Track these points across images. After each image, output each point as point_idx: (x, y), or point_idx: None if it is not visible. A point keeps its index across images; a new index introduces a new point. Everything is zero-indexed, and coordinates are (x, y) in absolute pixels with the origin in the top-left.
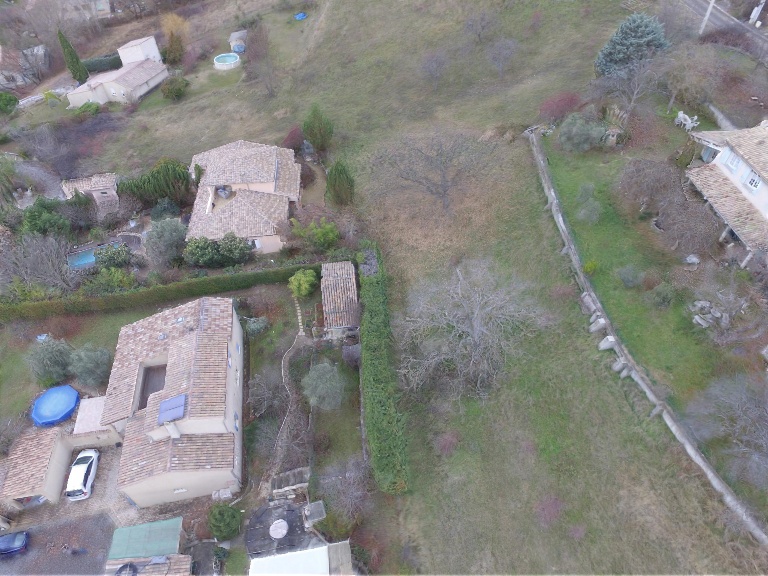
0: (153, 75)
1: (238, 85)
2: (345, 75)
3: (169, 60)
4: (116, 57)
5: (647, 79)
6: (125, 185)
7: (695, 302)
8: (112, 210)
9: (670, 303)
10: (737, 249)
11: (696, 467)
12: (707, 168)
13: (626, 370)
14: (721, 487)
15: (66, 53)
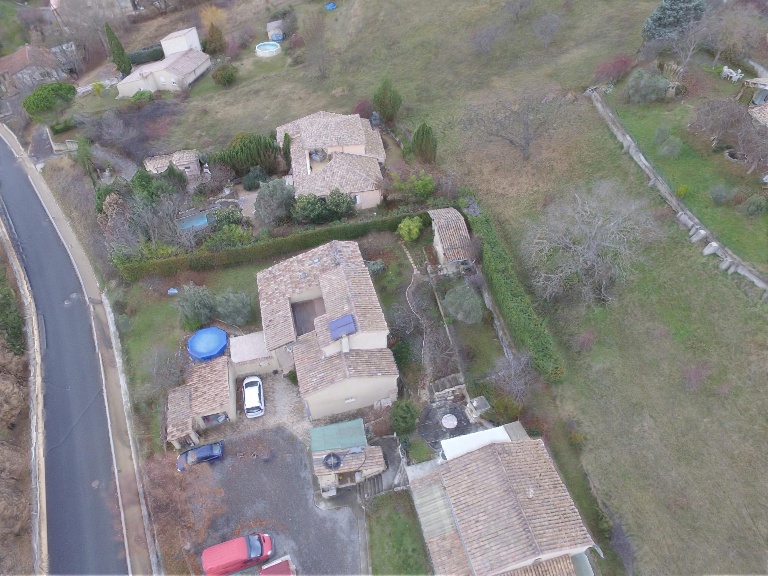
0: (199, 64)
1: (286, 69)
2: (392, 55)
3: (209, 50)
4: (155, 49)
5: (703, 36)
6: (218, 156)
7: None
8: (197, 183)
9: None
10: None
11: None
12: (767, 106)
13: (733, 266)
14: None
15: (113, 45)
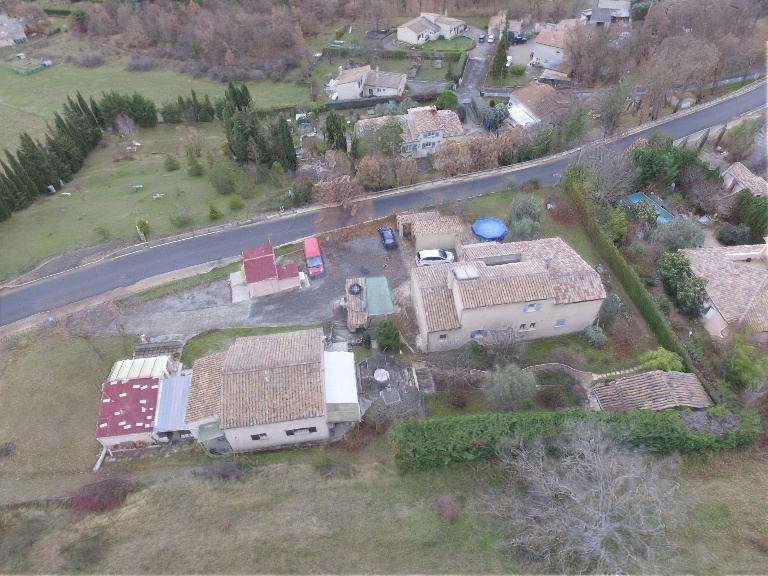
0: None
1: None
2: None
3: None
4: None
5: None
6: (745, 193)
7: None
8: None
9: None
10: None
11: None
12: None
13: None
14: None
15: None
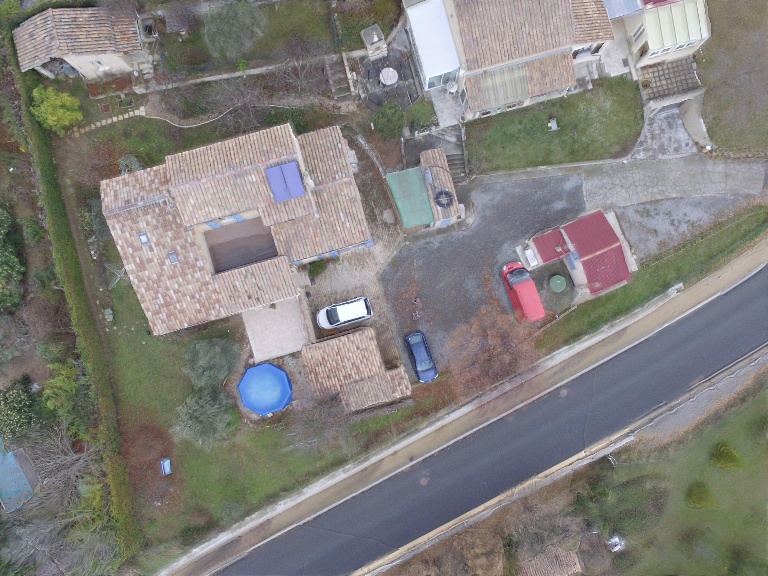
0: None
1: None
2: None
3: None
4: None
5: None
6: None
7: None
8: None
9: None
10: None
11: None
12: None
13: None
14: None
15: None
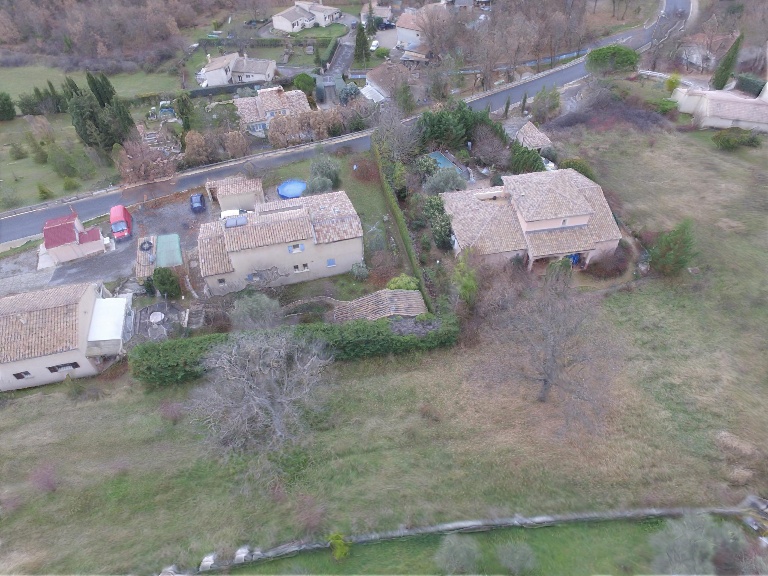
0: (750, 120)
1: None
2: None
3: None
4: None
5: None
6: (515, 145)
7: None
8: None
9: None
10: None
11: None
12: None
13: None
14: None
15: (723, 58)
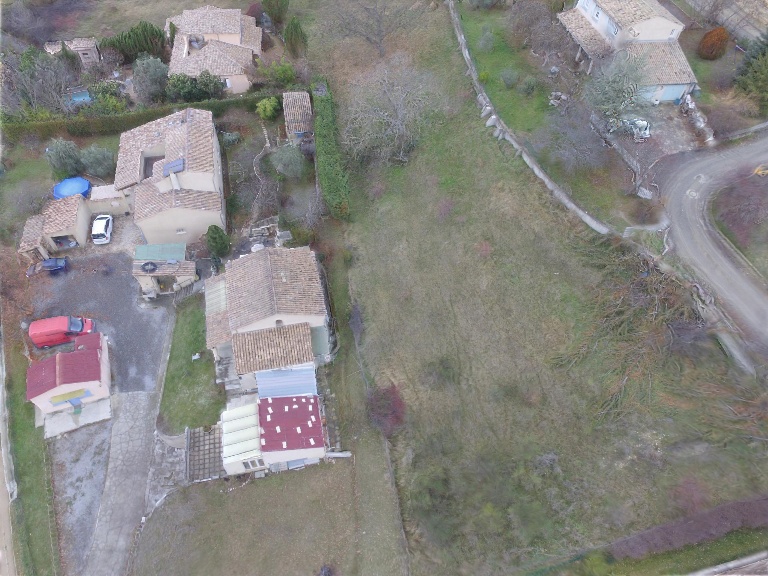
0: None
1: None
2: None
3: None
4: None
5: None
6: (108, 40)
7: (552, 92)
8: None
9: (535, 94)
10: (584, 61)
11: (539, 179)
12: (571, 11)
13: (501, 133)
14: (552, 187)
15: None
